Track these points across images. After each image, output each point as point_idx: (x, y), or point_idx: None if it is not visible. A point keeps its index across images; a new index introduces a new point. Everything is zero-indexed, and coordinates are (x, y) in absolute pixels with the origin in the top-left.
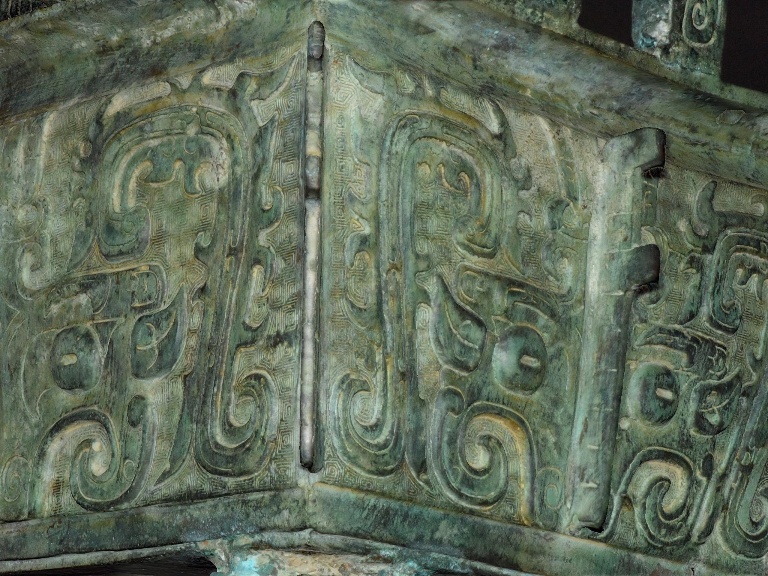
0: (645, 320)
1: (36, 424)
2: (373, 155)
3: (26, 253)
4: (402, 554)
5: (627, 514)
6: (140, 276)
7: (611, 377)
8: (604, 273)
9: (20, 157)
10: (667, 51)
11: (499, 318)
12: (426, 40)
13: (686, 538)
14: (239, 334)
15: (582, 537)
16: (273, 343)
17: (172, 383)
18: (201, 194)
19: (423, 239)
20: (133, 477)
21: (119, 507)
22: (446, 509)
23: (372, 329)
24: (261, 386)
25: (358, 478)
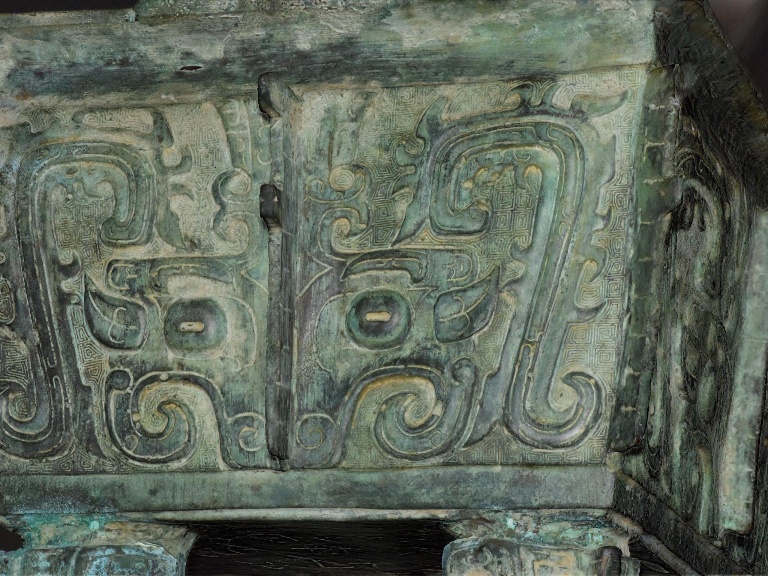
0: None
1: None
2: None
3: None
4: None
5: None
6: None
7: None
8: None
9: None
10: None
11: None
12: None
13: None
14: None
15: None
16: None
17: None
18: None
19: None
20: None
21: None
22: None
23: None
24: None
25: None
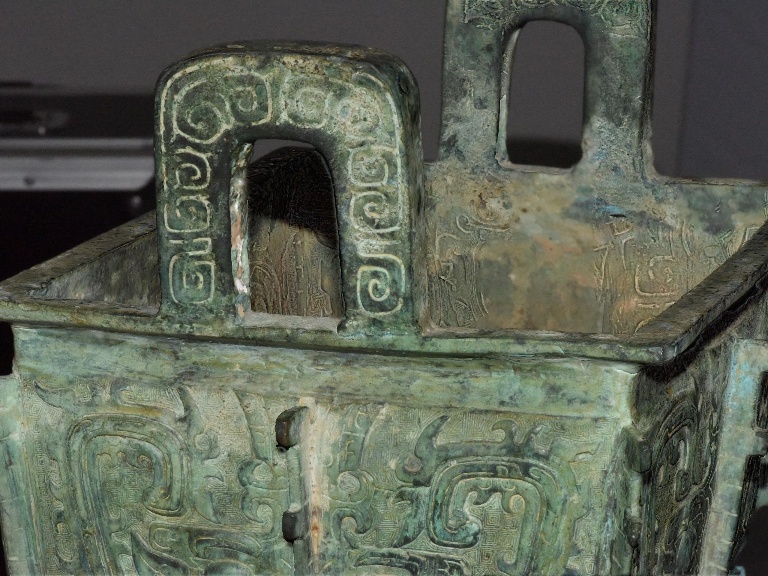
0: (355, 547)
1: None
2: (58, 453)
3: None
4: None
5: None
6: None
7: None
8: None
9: None
10: (344, 326)
11: (199, 558)
12: (122, 348)
13: None
14: None
15: None
16: None
17: None
18: None
19: (116, 507)
20: None
21: None
22: None
23: None
24: None
25: None
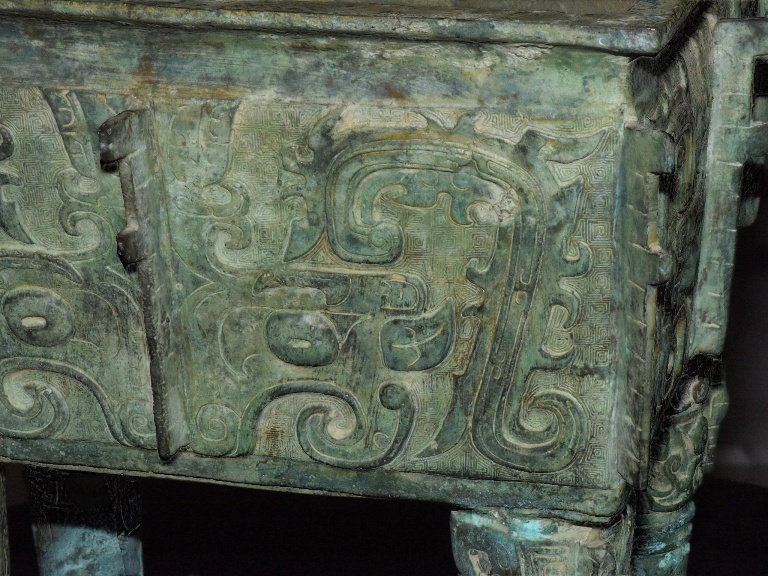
0: None
1: (243, 381)
2: None
3: (218, 231)
4: None
5: None
6: (393, 285)
7: (731, 237)
8: (720, 144)
9: (199, 139)
10: None
11: None
12: None
13: None
14: (535, 359)
15: None
16: (580, 373)
17: (437, 378)
18: (473, 225)
19: None
20: (387, 447)
21: None
22: None
23: None
24: (567, 408)
25: None
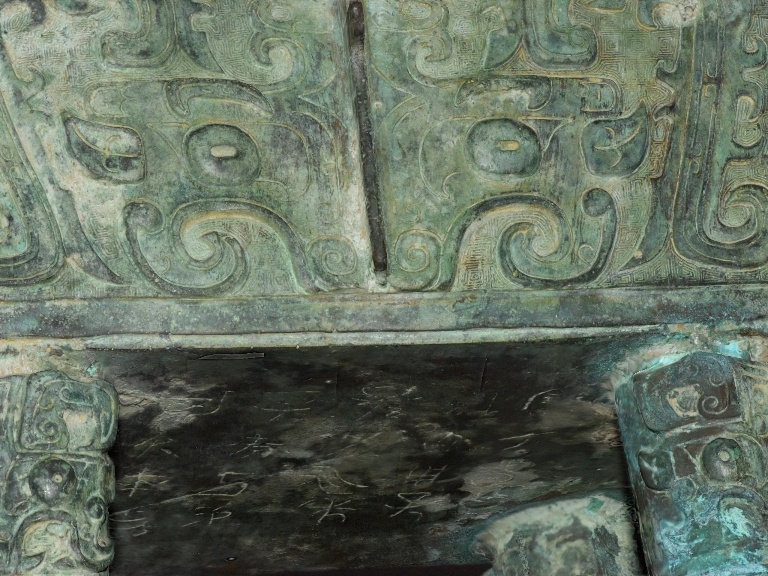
0: None
1: (444, 202)
2: None
3: (419, 44)
4: None
5: None
6: (592, 85)
7: None
8: None
9: None
10: None
11: None
12: None
13: None
14: (730, 149)
15: None
16: None
17: (636, 183)
18: (659, 28)
19: None
20: (593, 261)
21: (577, 286)
22: None
23: None
24: (765, 194)
25: None
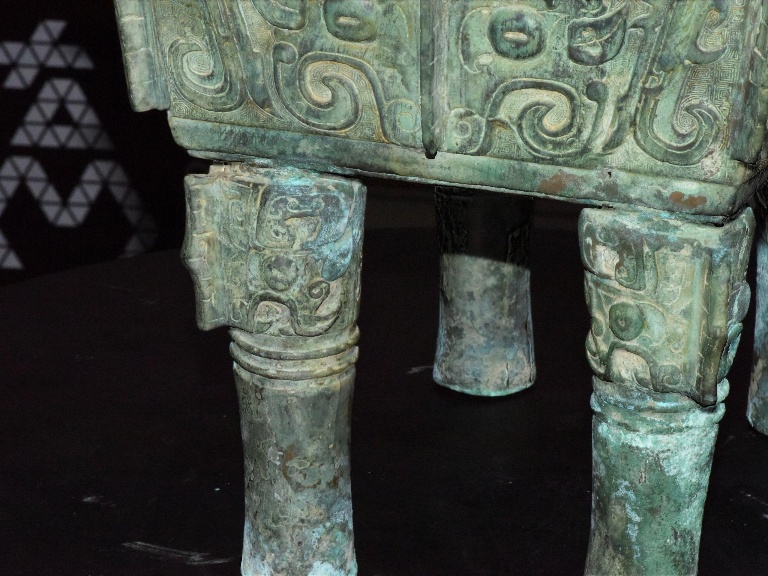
0: None
1: None
2: None
3: None
4: (278, 161)
5: (505, 132)
6: None
7: None
8: None
9: None
10: None
11: None
12: None
13: (583, 151)
14: None
15: (450, 152)
16: None
17: None
18: None
19: None
20: None
21: None
22: (302, 132)
23: (191, 6)
24: None
25: (205, 113)
